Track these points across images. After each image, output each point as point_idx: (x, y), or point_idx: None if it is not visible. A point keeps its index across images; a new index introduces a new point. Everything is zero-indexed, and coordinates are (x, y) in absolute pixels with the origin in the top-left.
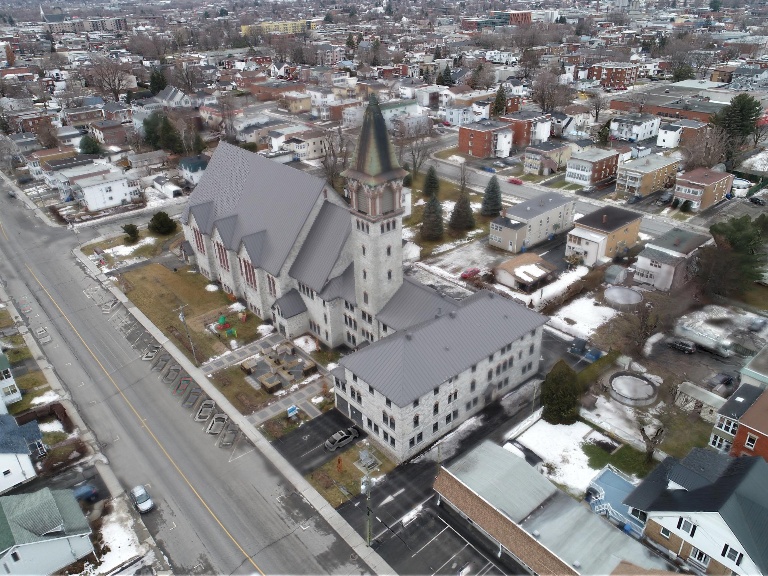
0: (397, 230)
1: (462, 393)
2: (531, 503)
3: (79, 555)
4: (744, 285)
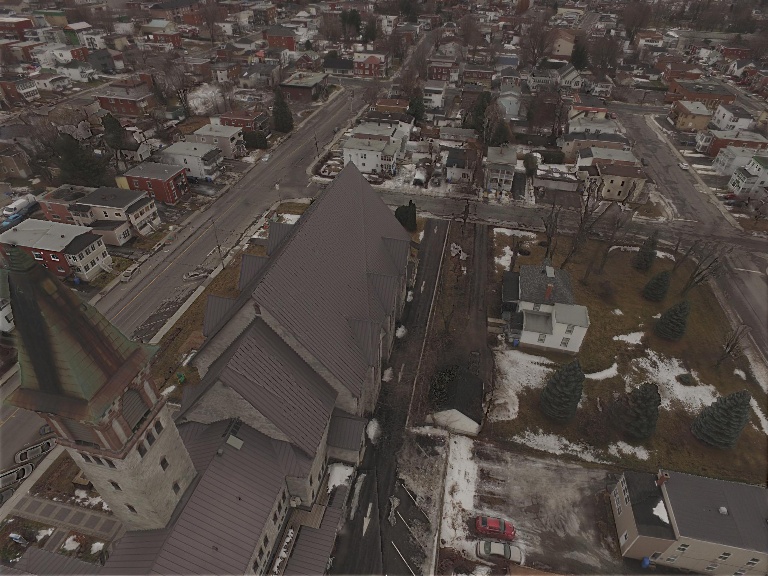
0: (121, 471)
1: None
2: None
3: None
4: None
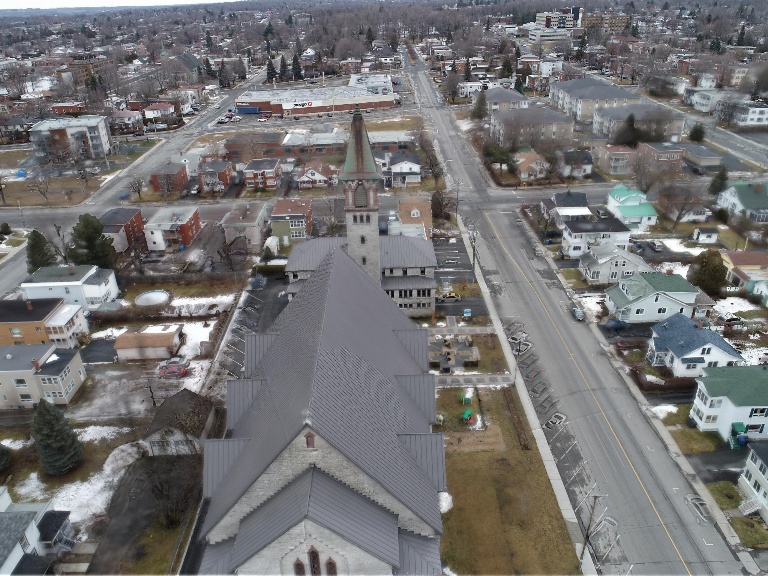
0: None
1: None
2: None
3: None
4: (117, 256)
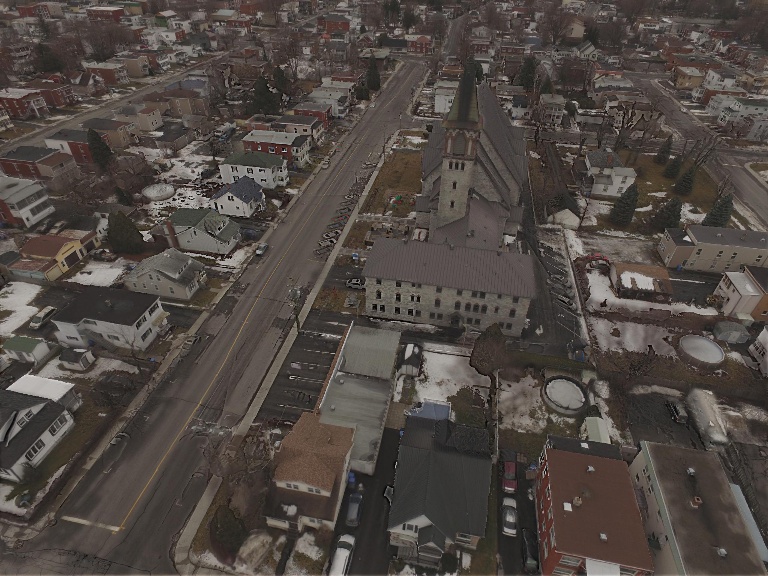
0: (465, 172)
1: (426, 301)
2: (364, 370)
3: (221, 252)
4: None
